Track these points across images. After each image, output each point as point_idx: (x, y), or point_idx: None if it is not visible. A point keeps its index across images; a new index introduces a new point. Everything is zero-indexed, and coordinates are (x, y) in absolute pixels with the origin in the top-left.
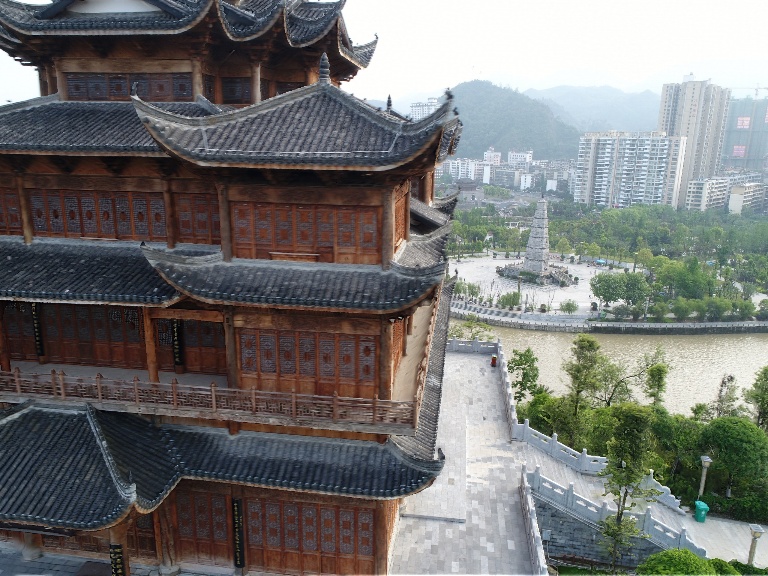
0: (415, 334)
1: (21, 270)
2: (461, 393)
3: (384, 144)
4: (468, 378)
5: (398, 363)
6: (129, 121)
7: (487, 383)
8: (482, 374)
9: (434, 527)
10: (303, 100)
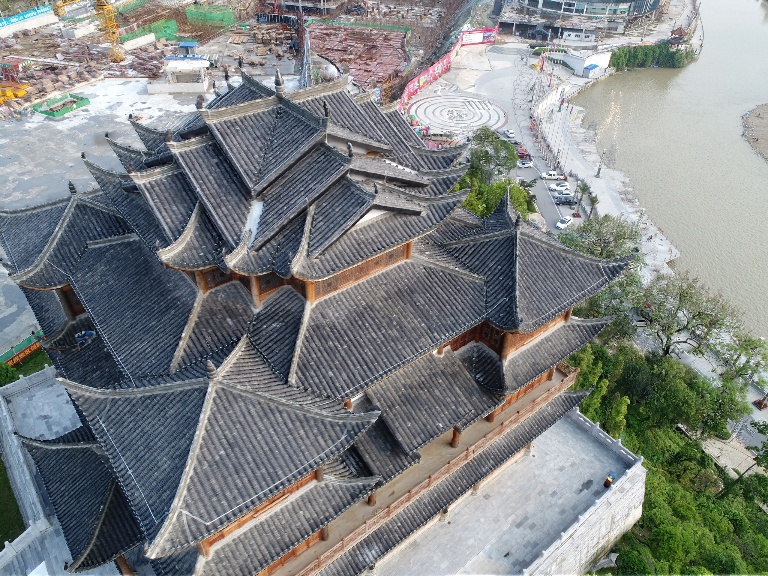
0: (380, 505)
1: (99, 369)
2: (526, 505)
3: (163, 509)
4: (558, 487)
5: (298, 553)
6: (147, 304)
7: (568, 507)
8: (579, 490)
9: None
10: (189, 390)
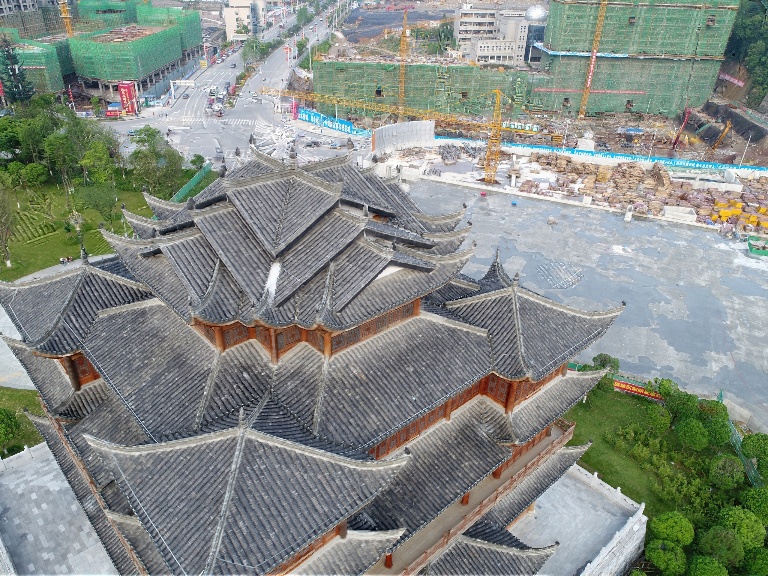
0: None
1: None
2: None
3: None
4: None
5: None
6: None
7: None
8: None
9: (89, 542)
10: None
